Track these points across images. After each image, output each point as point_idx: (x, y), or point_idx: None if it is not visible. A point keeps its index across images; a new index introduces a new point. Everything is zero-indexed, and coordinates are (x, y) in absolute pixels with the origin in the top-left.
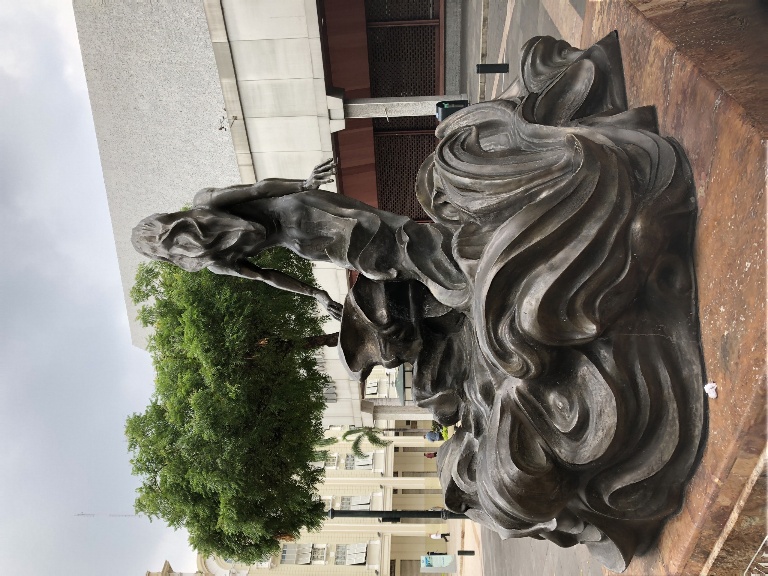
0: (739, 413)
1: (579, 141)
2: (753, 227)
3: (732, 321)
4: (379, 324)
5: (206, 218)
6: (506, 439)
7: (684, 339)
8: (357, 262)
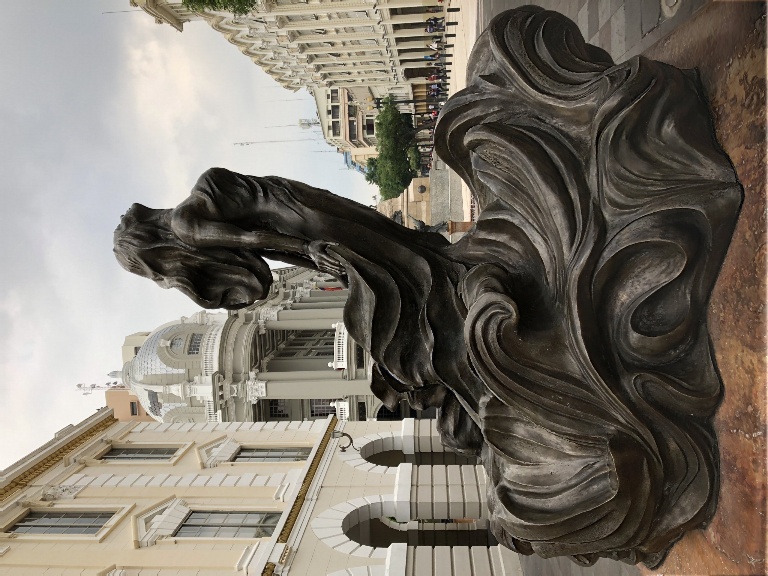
0: None
1: (618, 479)
2: None
3: None
4: None
5: (198, 262)
6: None
7: None
8: (382, 359)
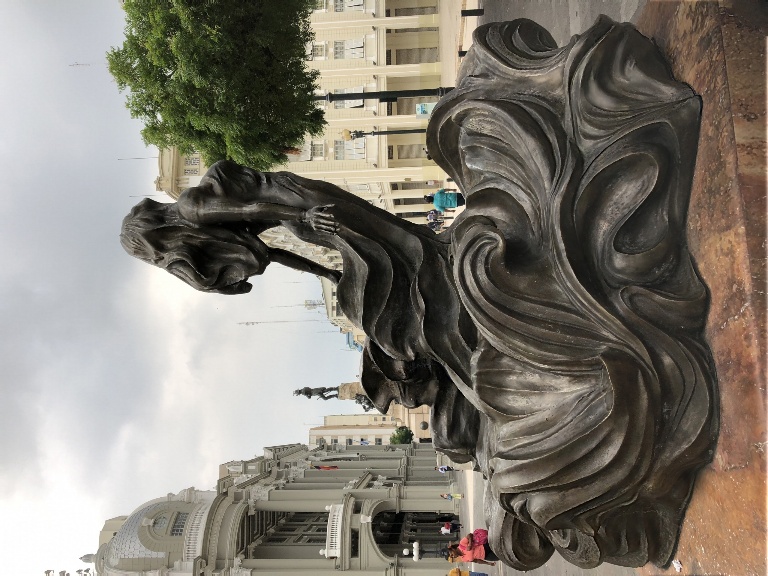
0: None
1: (613, 387)
2: (744, 575)
3: (706, 572)
4: (398, 380)
5: (199, 240)
6: (509, 530)
7: (668, 519)
8: (373, 332)
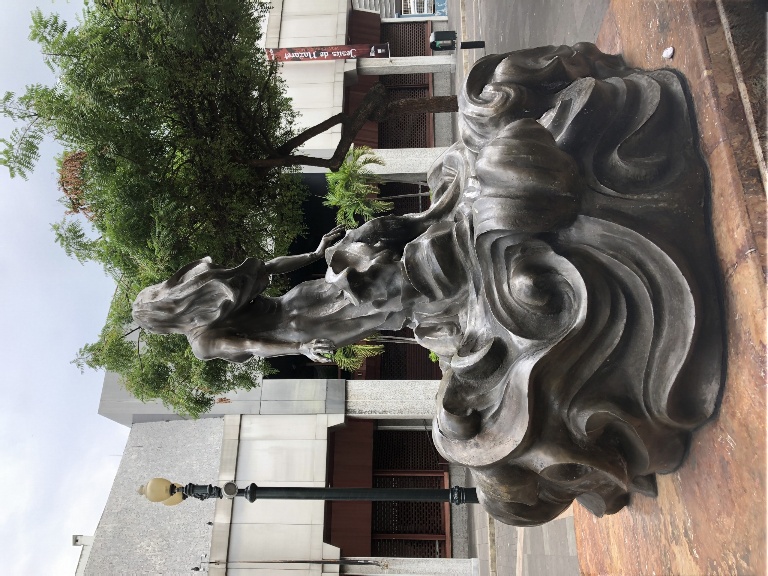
0: (684, 8)
1: None
2: None
3: (656, 8)
4: None
5: None
6: None
7: None
8: None
